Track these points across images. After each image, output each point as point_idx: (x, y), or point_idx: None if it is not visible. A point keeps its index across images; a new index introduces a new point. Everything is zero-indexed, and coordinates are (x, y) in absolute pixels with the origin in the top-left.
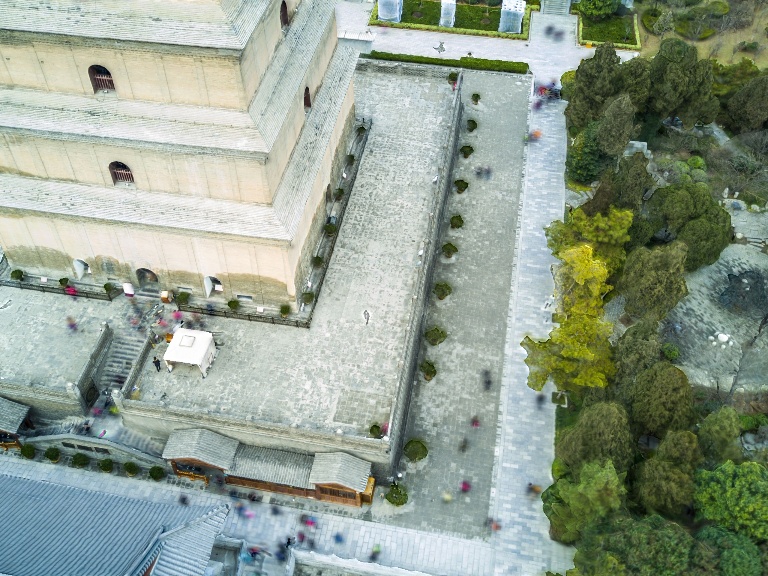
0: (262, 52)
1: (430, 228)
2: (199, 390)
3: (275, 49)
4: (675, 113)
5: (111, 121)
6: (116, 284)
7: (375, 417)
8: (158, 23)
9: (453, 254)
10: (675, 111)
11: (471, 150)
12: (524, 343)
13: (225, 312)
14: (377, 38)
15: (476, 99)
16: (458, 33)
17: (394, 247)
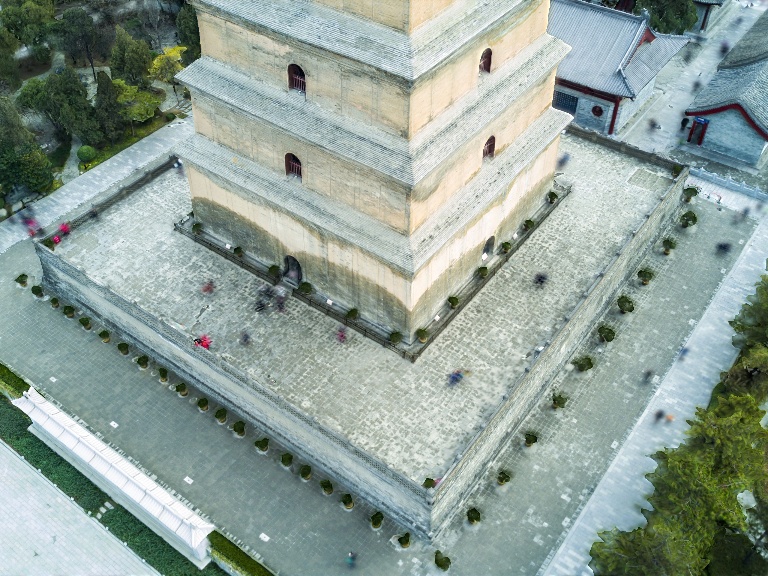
0: None
1: None
2: None
3: None
4: None
5: None
6: None
7: None
8: None
9: None
10: None
11: None
12: None
13: None
14: None
15: (25, 275)
16: None
17: None
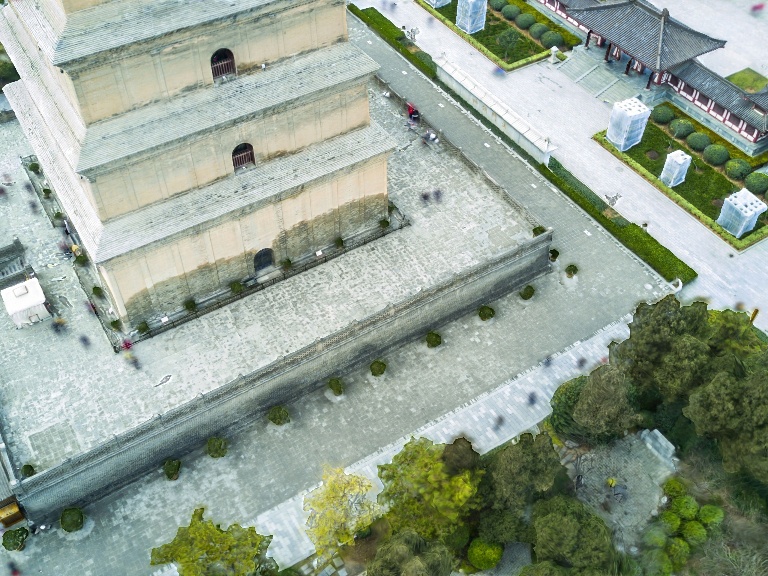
0: (145, 83)
1: (305, 350)
2: (4, 334)
3: (187, 89)
4: (721, 438)
5: (35, 78)
6: (67, 217)
7: (53, 461)
8: (36, 11)
9: (344, 394)
10: (721, 436)
11: (488, 315)
12: (196, 512)
13: (87, 292)
14: (583, 155)
15: (568, 271)
16: (671, 197)
17: (266, 343)
